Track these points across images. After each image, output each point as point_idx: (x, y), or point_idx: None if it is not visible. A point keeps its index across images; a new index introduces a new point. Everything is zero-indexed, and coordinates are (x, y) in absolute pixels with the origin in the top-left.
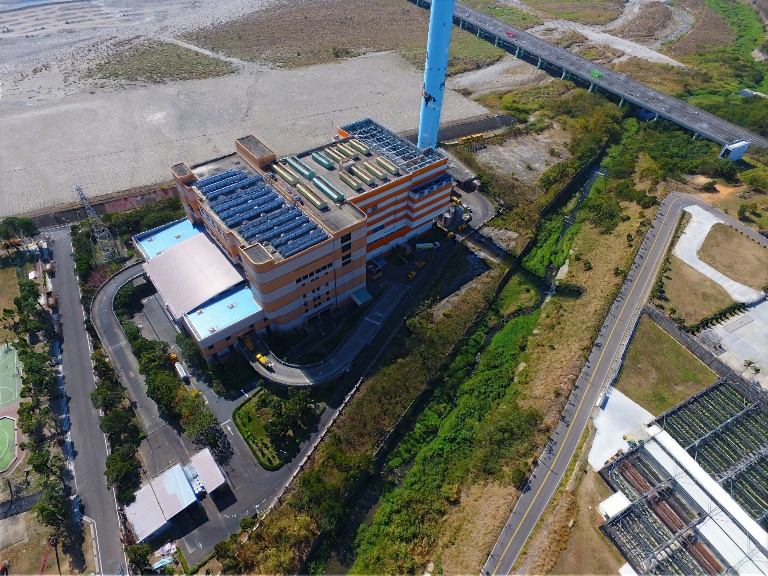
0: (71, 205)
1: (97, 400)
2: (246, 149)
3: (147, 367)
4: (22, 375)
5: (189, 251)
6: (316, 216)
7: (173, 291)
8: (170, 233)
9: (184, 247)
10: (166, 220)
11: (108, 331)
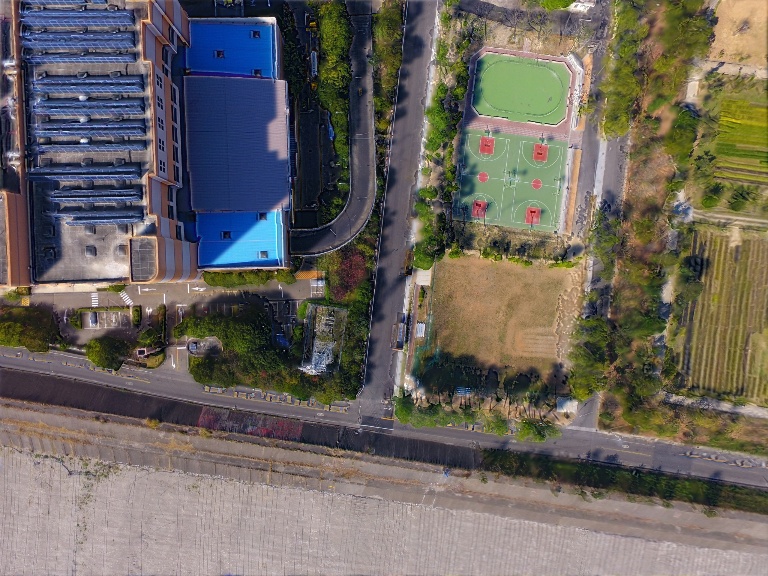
0: (344, 471)
1: (397, 51)
2: (8, 237)
3: (341, 65)
4: (458, 163)
5: (224, 181)
6: (10, 18)
7: (272, 127)
8: (234, 251)
9: (227, 195)
10: (231, 322)
11: (365, 165)
